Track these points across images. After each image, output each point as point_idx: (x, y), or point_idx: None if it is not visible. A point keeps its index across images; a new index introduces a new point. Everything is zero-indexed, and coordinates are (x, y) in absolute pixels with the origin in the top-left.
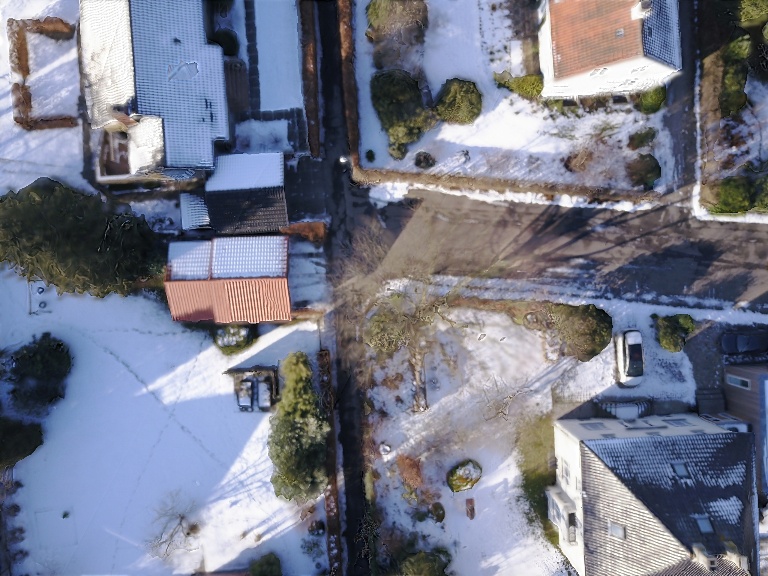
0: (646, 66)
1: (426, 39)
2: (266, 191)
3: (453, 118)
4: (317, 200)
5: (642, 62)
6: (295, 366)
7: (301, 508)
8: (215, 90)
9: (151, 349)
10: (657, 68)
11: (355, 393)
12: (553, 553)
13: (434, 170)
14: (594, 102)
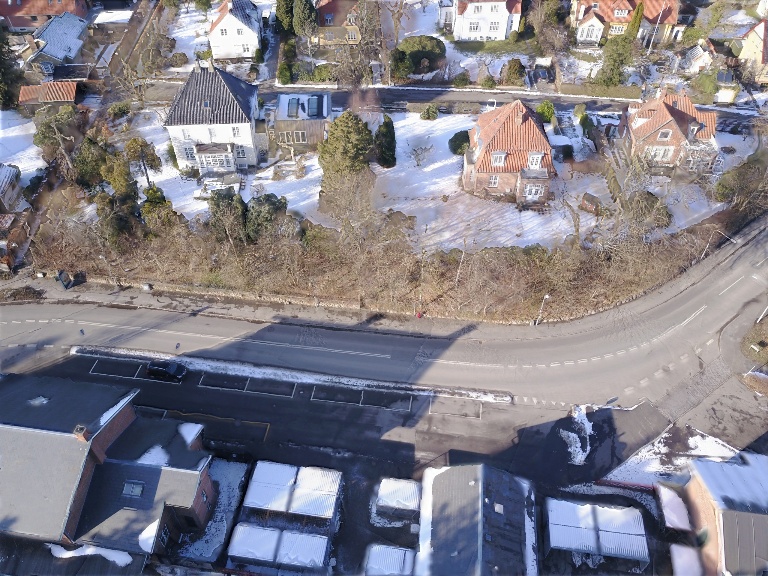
0: (241, 31)
1: (173, 52)
2: (81, 66)
3: (176, 66)
4: (107, 85)
5: (231, 18)
6: (67, 106)
7: (46, 165)
8: (75, 47)
9: (2, 123)
10: (248, 34)
11: (96, 132)
12: (175, 171)
13: (163, 77)
14: (237, 62)
